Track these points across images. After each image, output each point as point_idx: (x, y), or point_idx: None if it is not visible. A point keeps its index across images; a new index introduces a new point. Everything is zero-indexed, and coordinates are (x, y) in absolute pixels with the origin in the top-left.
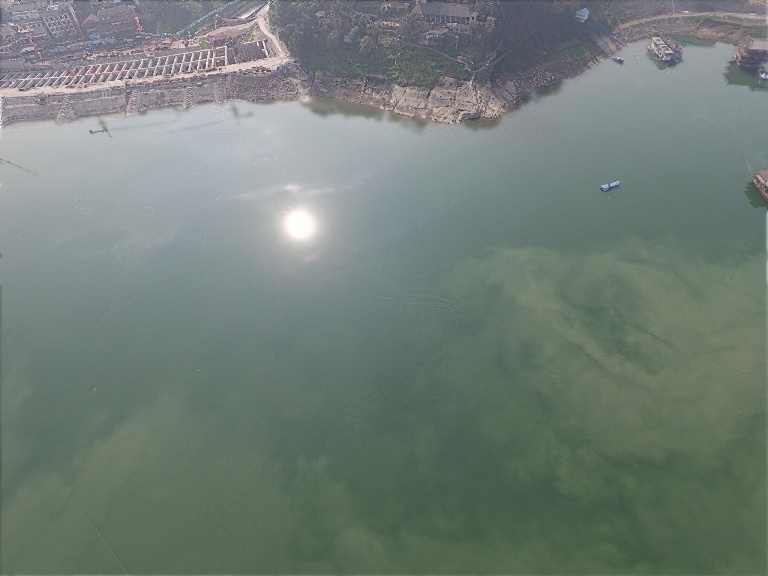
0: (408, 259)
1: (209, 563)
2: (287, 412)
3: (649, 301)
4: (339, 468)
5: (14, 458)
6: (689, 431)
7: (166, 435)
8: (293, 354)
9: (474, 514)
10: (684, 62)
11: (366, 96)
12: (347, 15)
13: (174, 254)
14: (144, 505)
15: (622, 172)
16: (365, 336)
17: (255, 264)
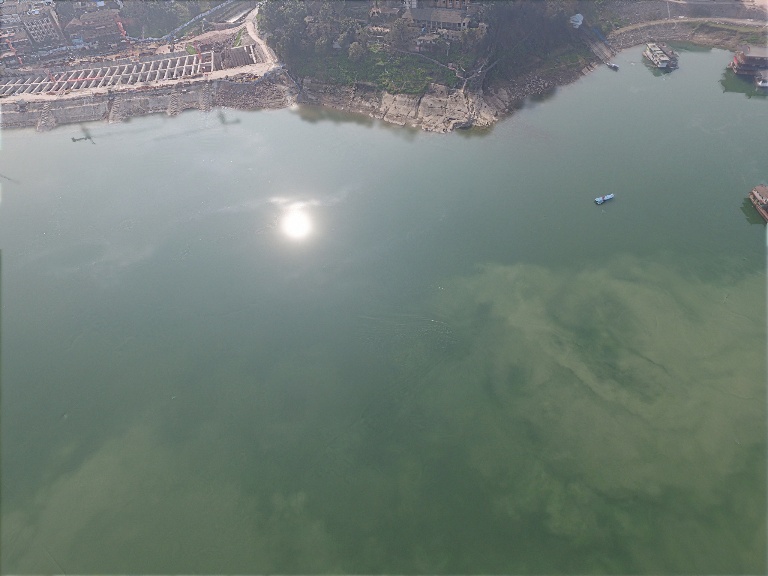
0: (395, 277)
1: None
2: (266, 441)
3: (644, 321)
4: (319, 505)
5: None
6: (686, 462)
7: (139, 467)
8: (274, 379)
9: (460, 555)
10: (680, 69)
11: (355, 104)
12: (336, 20)
13: (153, 271)
14: (113, 544)
15: (616, 184)
16: (349, 359)
17: (237, 281)
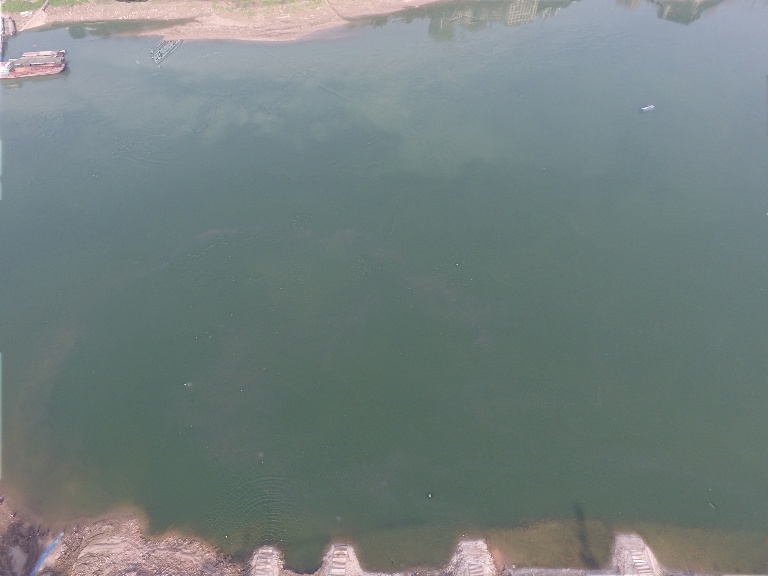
0: (122, 183)
1: (297, 91)
2: (252, 126)
3: None
4: None
5: (405, 121)
6: None
7: (322, 125)
8: None
9: None
10: None
11: None
12: None
13: (324, 206)
14: (329, 105)
15: None
16: None
17: (255, 205)
